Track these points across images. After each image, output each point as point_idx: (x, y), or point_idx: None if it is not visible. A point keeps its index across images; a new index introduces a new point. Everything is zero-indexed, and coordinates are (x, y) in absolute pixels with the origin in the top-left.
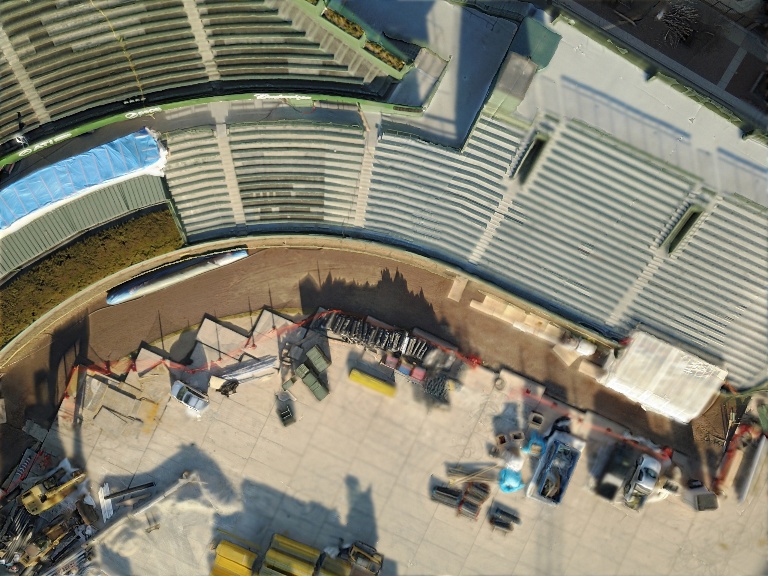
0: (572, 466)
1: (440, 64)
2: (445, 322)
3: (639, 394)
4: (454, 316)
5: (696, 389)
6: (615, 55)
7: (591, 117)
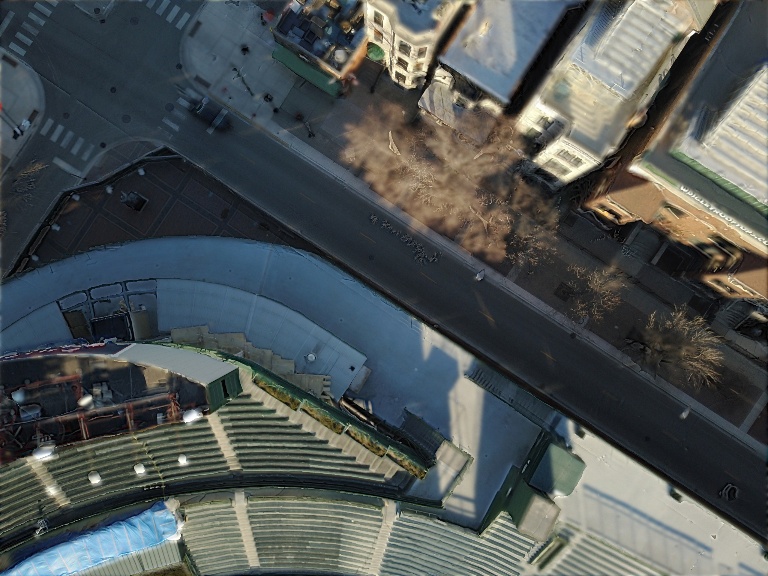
0: None
1: (462, 457)
2: None
3: None
4: None
5: None
6: (639, 467)
7: (612, 528)
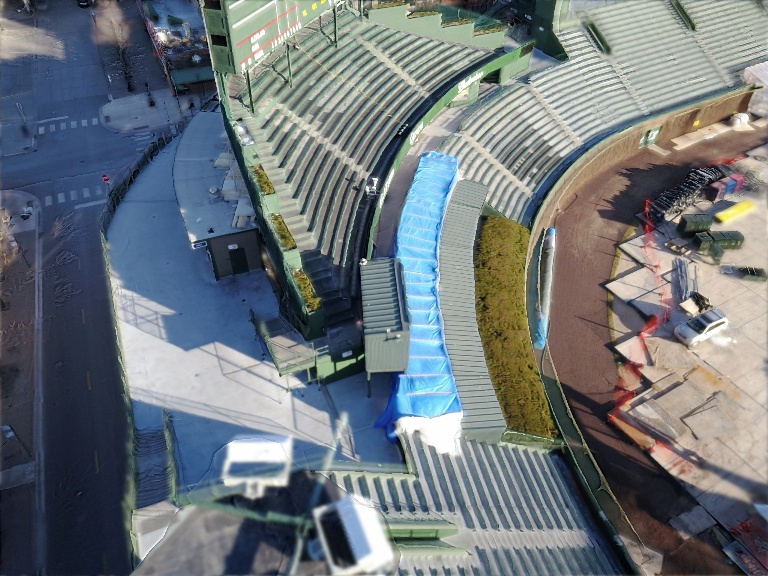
0: None
1: None
2: (687, 164)
3: None
4: (684, 157)
5: None
6: None
7: (590, 4)
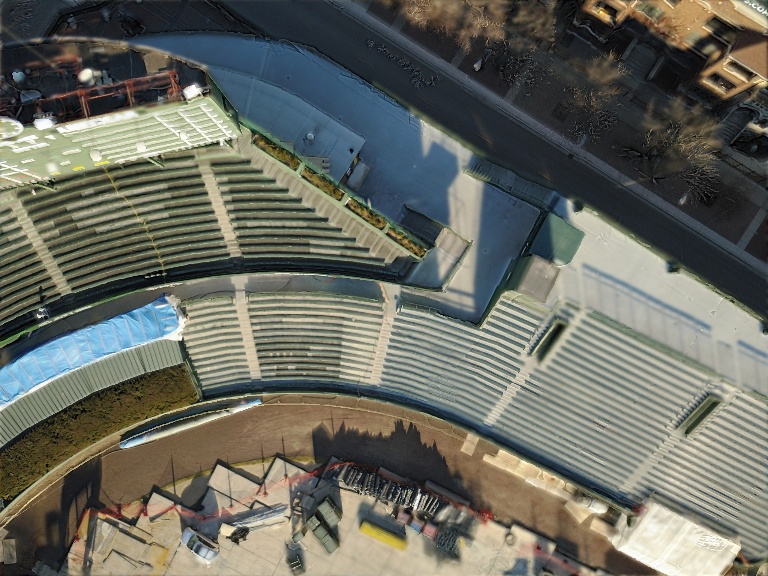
0: None
1: (461, 244)
2: (457, 475)
3: (651, 561)
4: (467, 470)
5: (708, 561)
6: (637, 245)
7: (612, 306)
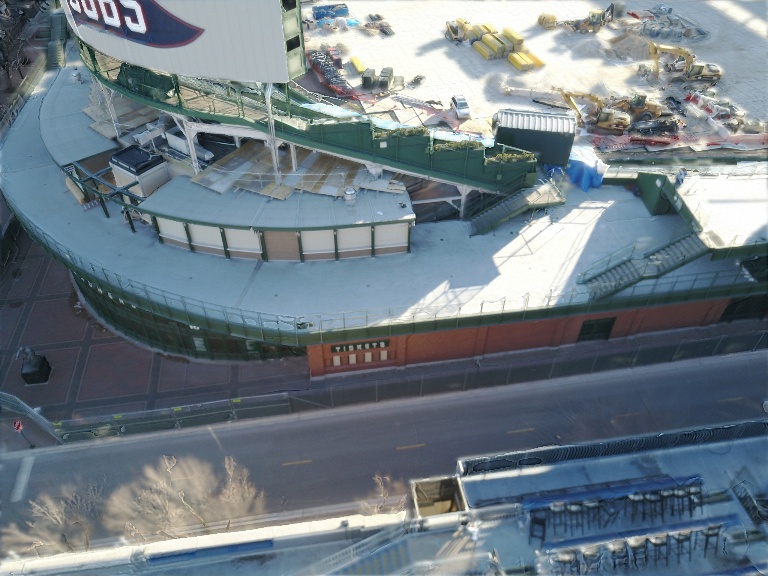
0: (322, 8)
1: None
2: None
3: None
4: None
5: None
6: None
7: None
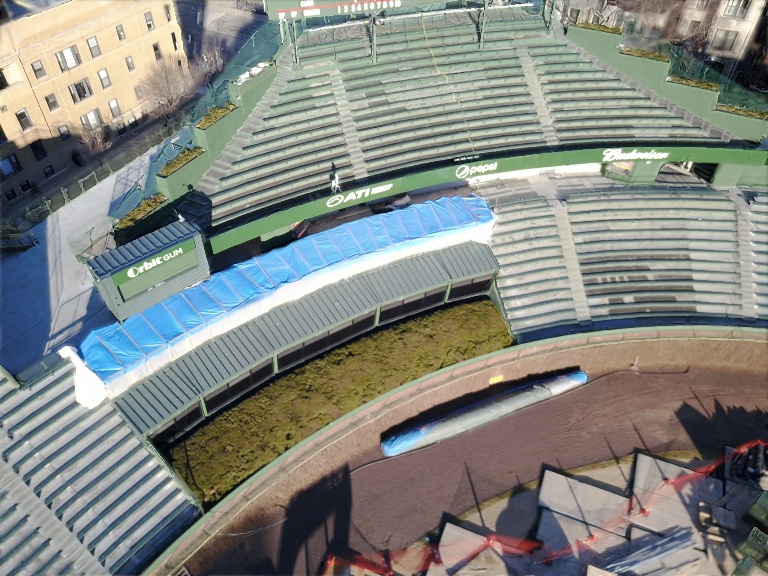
0: None
1: None
2: None
3: None
4: None
5: None
6: None
7: None
